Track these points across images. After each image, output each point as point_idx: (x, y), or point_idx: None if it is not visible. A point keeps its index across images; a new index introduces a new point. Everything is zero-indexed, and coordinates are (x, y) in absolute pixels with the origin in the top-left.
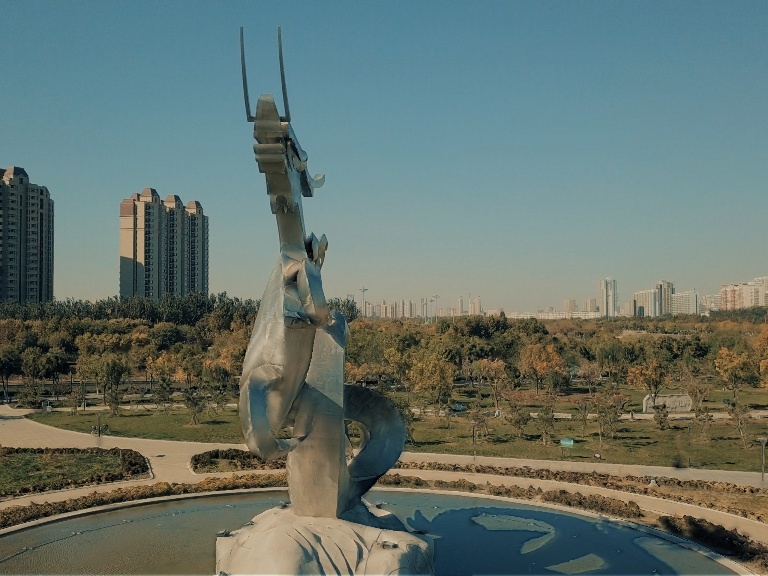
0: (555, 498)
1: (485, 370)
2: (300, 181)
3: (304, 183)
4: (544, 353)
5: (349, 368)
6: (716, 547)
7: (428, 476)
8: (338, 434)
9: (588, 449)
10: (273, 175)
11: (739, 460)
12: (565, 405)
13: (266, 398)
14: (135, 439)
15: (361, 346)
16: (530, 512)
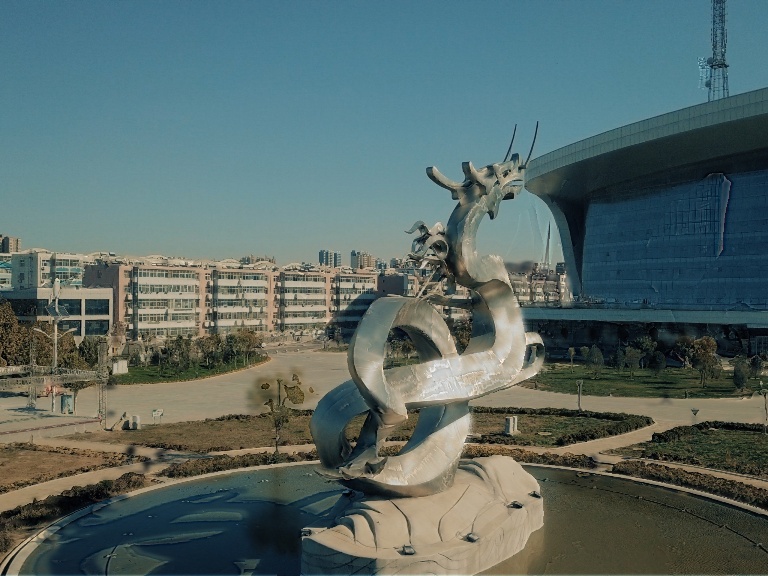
0: None
1: None
2: None
3: None
4: None
5: None
6: (82, 505)
7: None
8: None
9: None
10: None
11: None
12: None
13: None
14: None
15: None
16: (48, 574)
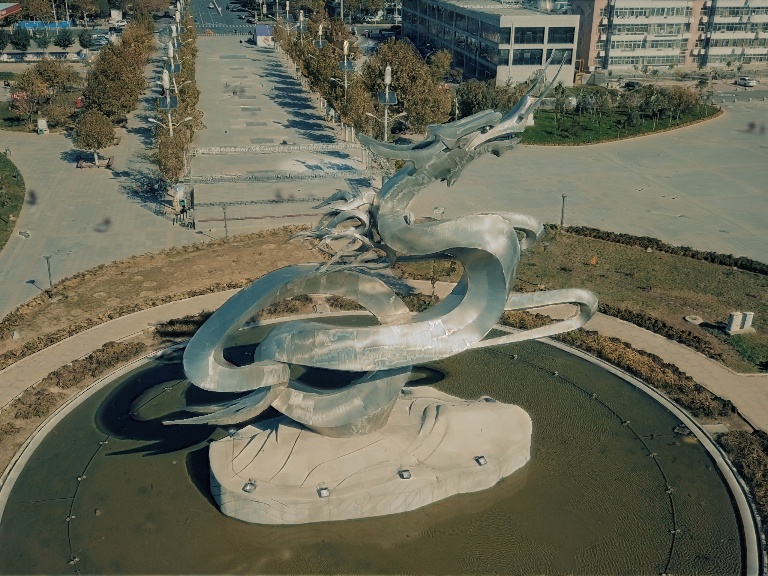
0: None
1: None
2: None
3: None
4: None
5: None
6: None
7: None
8: None
9: None
10: None
11: None
12: None
13: None
14: None
15: None
16: (118, 393)
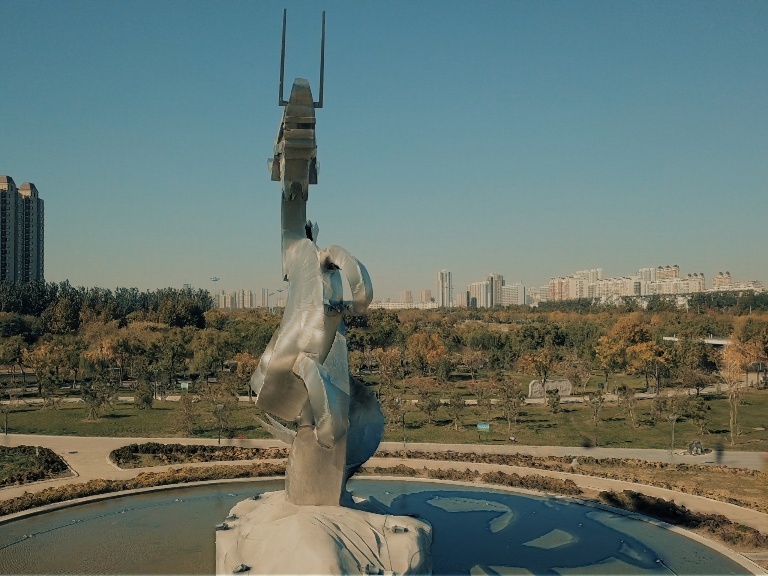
0: (496, 479)
1: (387, 359)
2: (309, 168)
3: (312, 170)
4: (430, 342)
5: (247, 358)
6: (661, 517)
7: None
8: (345, 422)
9: (499, 433)
10: (293, 161)
11: (635, 439)
12: (454, 392)
13: (294, 387)
14: (33, 436)
15: (244, 336)
16: (478, 493)
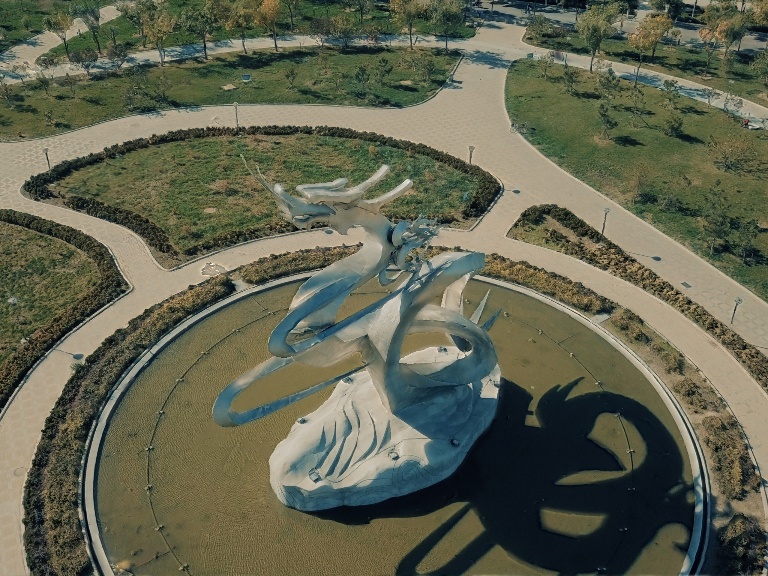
0: (708, 428)
1: None
2: None
3: None
4: None
5: None
6: None
7: (671, 327)
8: (382, 375)
9: None
10: None
11: None
12: None
13: None
14: (534, 149)
15: None
16: (662, 432)
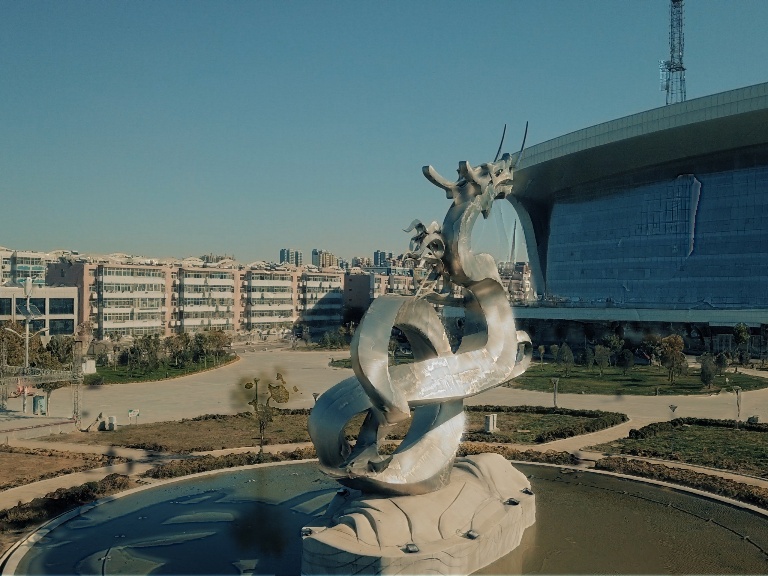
0: None
1: None
2: None
3: None
4: None
5: None
6: (68, 507)
7: None
8: None
9: None
10: None
11: None
12: None
13: None
14: None
15: None
16: None
